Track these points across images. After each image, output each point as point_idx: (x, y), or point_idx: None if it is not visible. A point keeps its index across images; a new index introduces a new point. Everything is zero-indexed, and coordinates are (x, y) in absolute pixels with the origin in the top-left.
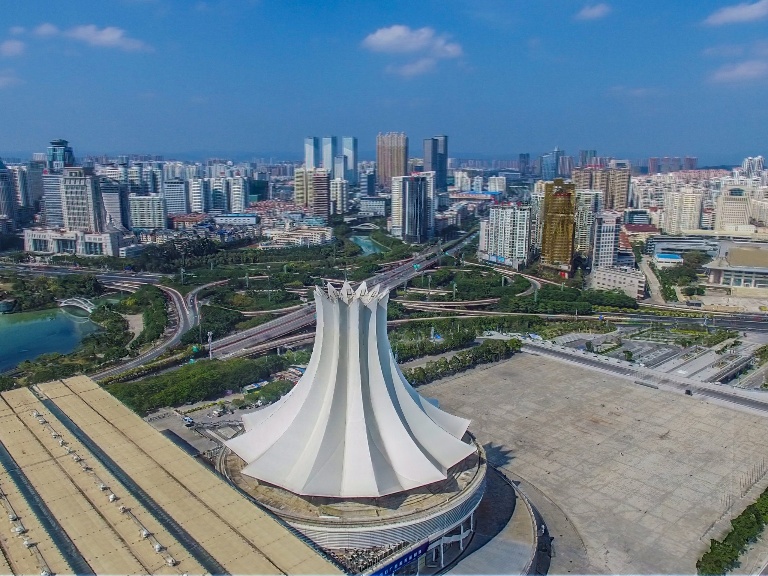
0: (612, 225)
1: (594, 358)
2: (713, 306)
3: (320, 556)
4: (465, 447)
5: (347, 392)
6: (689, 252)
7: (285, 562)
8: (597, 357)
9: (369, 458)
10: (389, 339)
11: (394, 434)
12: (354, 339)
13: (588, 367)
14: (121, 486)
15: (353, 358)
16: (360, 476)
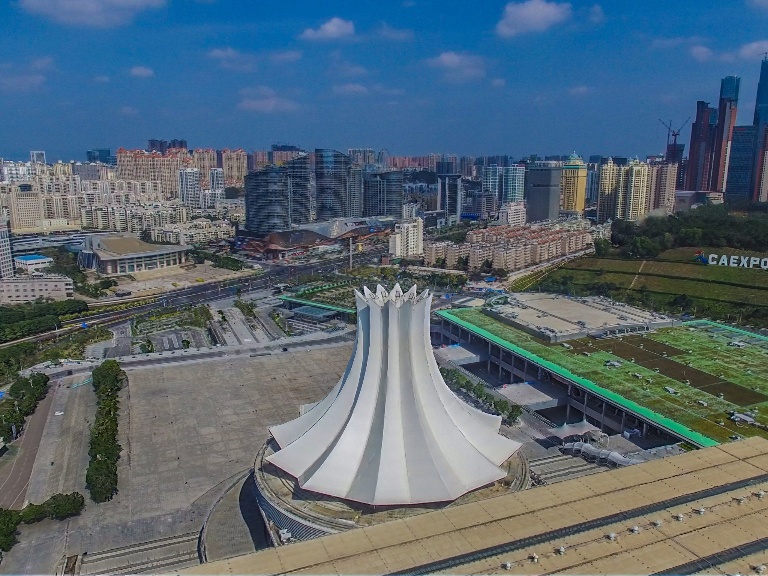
0: (5, 230)
1: (175, 354)
2: (142, 292)
3: (639, 464)
4: None
5: None
6: (42, 251)
7: (647, 478)
8: (176, 353)
9: (486, 427)
10: None
11: None
12: (427, 335)
13: (189, 362)
14: (503, 555)
15: (426, 354)
16: (492, 444)
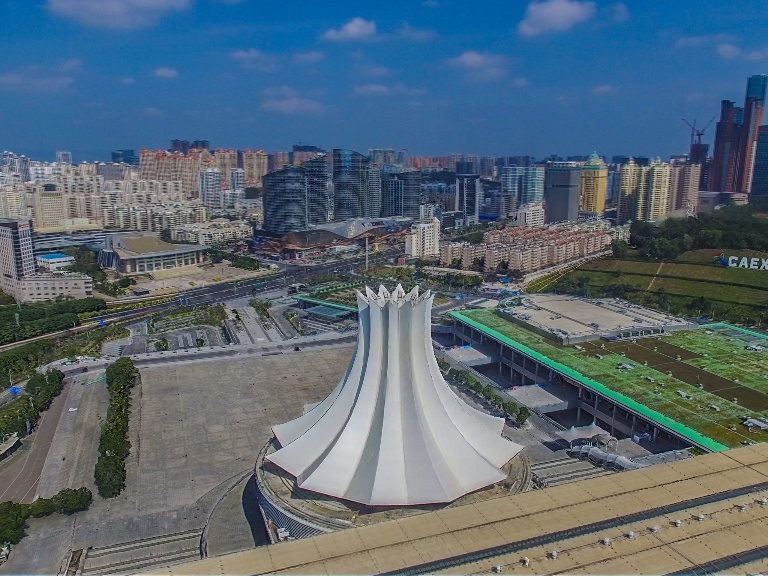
0: (27, 229)
1: (189, 353)
2: (159, 291)
3: None
4: None
5: None
6: (64, 249)
7: (647, 483)
8: (190, 351)
9: (487, 429)
10: None
11: None
12: (428, 336)
13: (202, 360)
14: (494, 558)
15: (427, 355)
16: (493, 446)
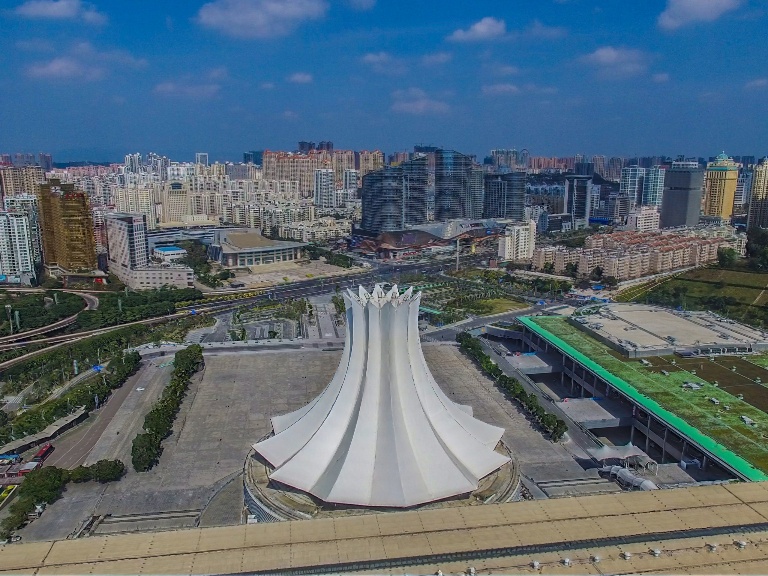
0: (141, 223)
1: (258, 344)
2: (254, 284)
3: None
4: (466, 408)
5: (417, 392)
6: (180, 243)
7: (618, 509)
8: (259, 342)
9: (473, 437)
10: (6, 393)
11: (452, 414)
12: (414, 338)
13: None
14: (410, 567)
15: (413, 357)
16: (477, 455)
